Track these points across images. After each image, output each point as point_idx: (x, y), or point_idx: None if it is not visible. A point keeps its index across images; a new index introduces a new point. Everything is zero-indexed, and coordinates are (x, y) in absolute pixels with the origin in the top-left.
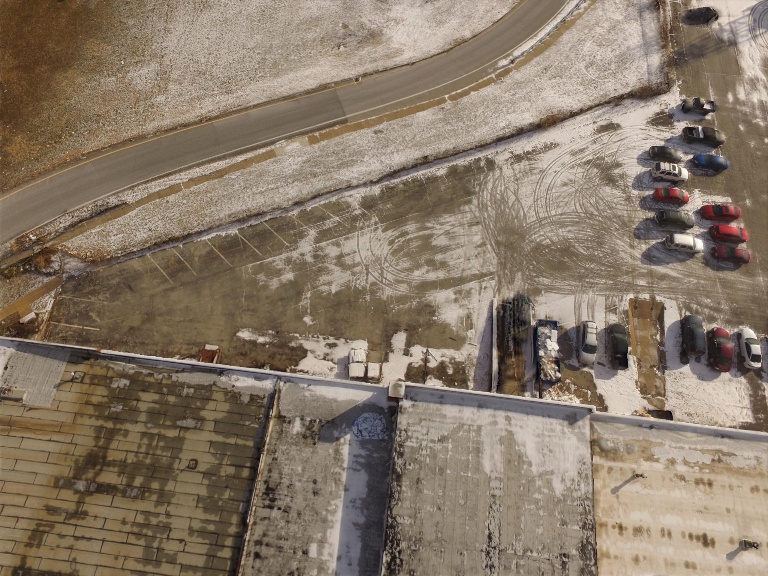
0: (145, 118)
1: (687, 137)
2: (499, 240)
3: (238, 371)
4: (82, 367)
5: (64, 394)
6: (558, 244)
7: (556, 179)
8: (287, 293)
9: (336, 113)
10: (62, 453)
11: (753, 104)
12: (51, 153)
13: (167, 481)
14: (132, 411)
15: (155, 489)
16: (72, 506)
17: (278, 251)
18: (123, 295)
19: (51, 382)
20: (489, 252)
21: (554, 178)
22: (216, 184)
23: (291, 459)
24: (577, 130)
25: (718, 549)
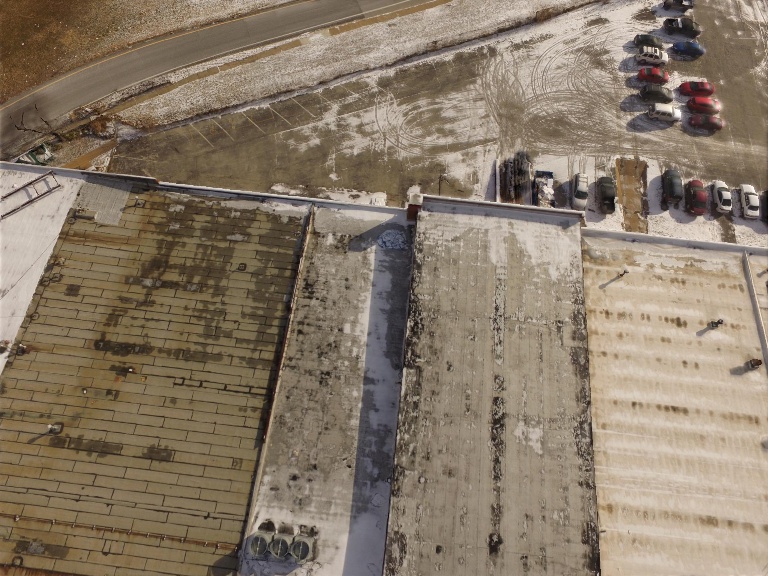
0: (182, 16)
1: (668, 27)
2: (501, 112)
3: (278, 199)
4: (143, 196)
5: (129, 216)
6: (553, 115)
7: (551, 63)
8: (315, 155)
9: (354, 10)
10: (130, 259)
11: (727, 4)
12: (100, 44)
13: (221, 279)
14: (188, 229)
15: (211, 285)
16: (141, 297)
17: (306, 121)
18: (170, 156)
19: (117, 207)
20: (492, 122)
21: (549, 62)
22: (249, 67)
23: (326, 263)
24: (570, 24)
25: (689, 328)
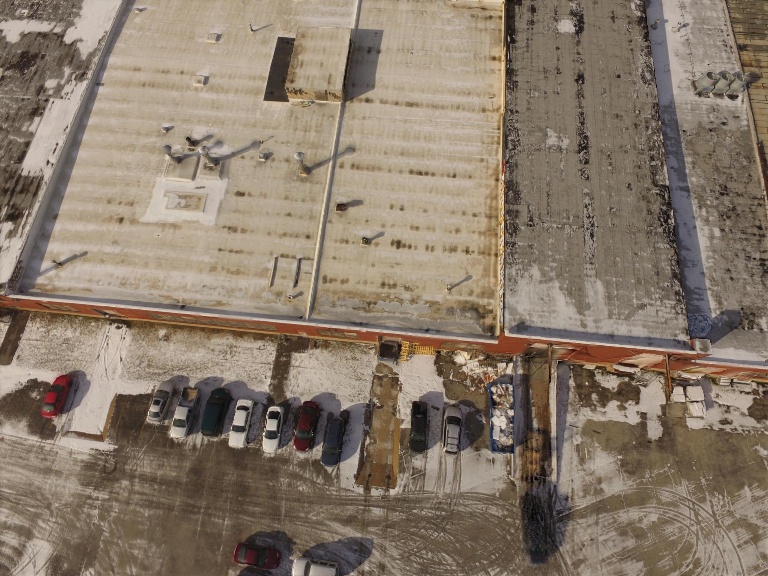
0: None
1: None
2: (556, 572)
3: None
4: None
5: None
6: (479, 568)
7: None
8: None
9: None
10: None
11: None
12: None
13: None
14: None
15: None
16: None
17: None
18: None
19: None
20: (568, 552)
21: None
22: None
23: (759, 296)
24: None
25: (389, 239)
